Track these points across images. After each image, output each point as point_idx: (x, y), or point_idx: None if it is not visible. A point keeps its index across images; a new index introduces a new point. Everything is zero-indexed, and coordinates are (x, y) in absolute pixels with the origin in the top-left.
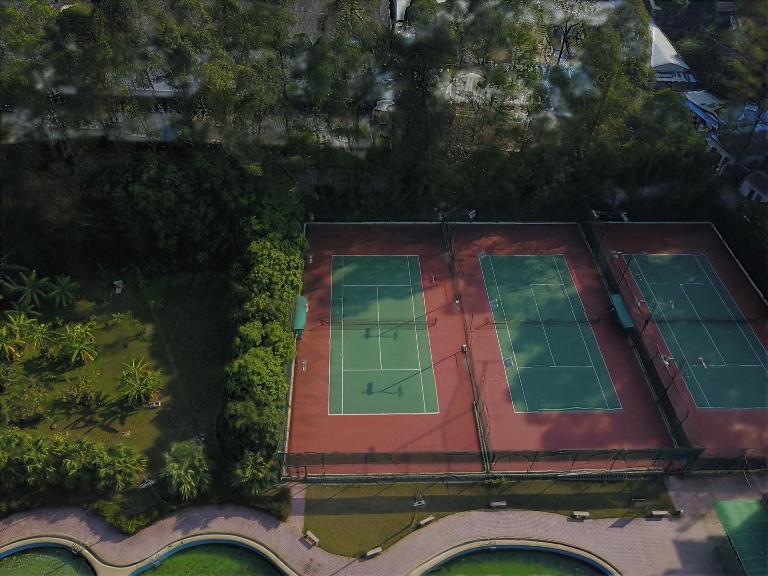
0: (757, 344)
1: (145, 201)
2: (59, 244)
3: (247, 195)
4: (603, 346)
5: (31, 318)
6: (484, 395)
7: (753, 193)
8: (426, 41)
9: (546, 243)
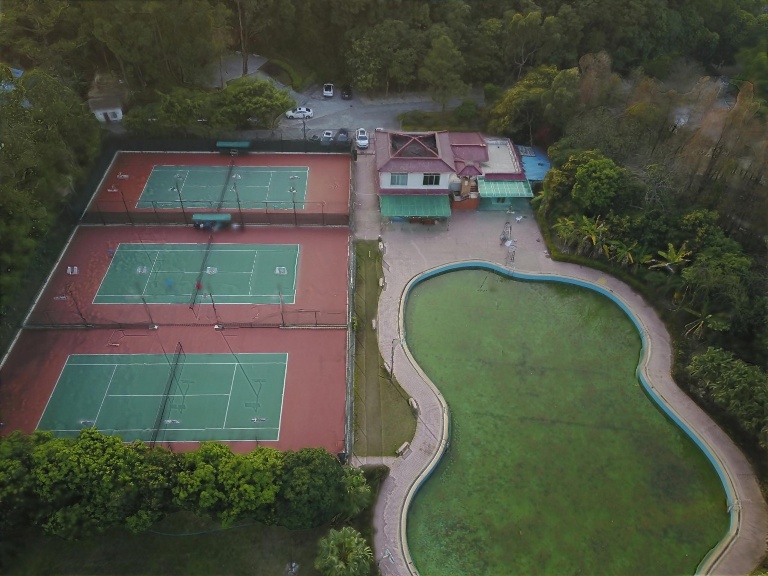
0: (253, 168)
1: None
2: None
3: None
4: (237, 241)
5: None
6: (289, 308)
7: (106, 115)
8: None
9: (98, 251)
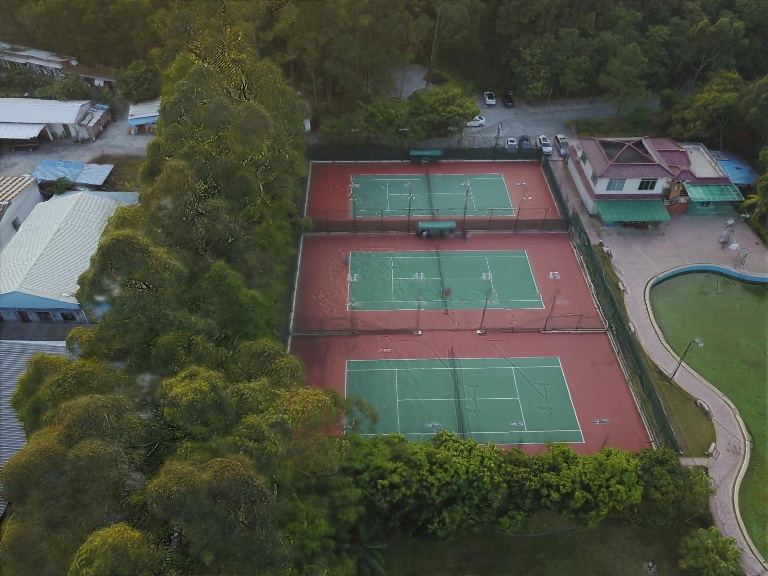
0: (449, 176)
1: None
2: None
3: (346, 488)
4: (463, 248)
5: None
6: (556, 313)
7: None
8: (247, 178)
9: (333, 259)
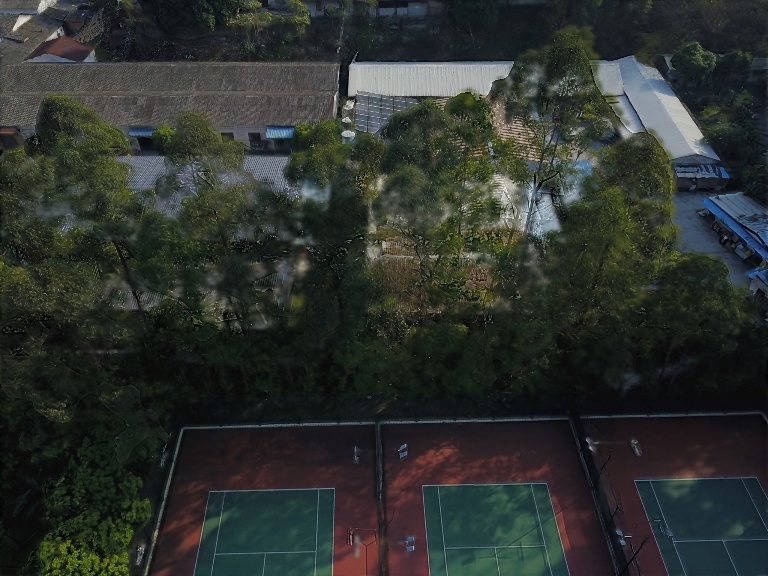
0: None
1: None
2: None
3: (56, 441)
4: None
5: None
6: None
7: None
8: (311, 216)
9: (522, 460)
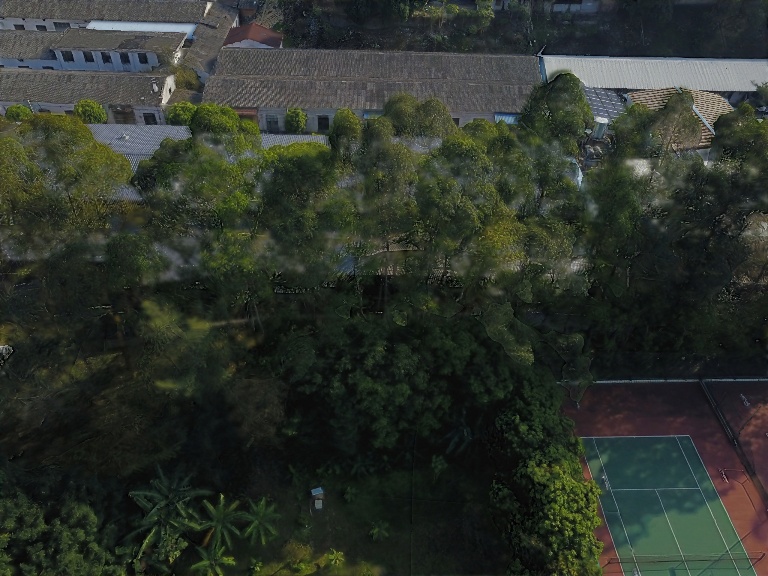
0: None
1: (370, 398)
2: (243, 446)
3: (502, 383)
4: None
5: (225, 571)
6: None
7: None
8: (767, 184)
9: None
